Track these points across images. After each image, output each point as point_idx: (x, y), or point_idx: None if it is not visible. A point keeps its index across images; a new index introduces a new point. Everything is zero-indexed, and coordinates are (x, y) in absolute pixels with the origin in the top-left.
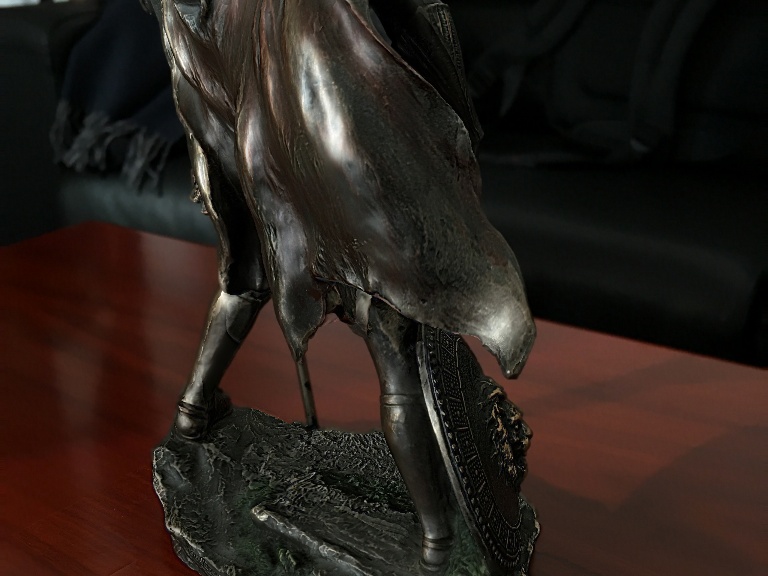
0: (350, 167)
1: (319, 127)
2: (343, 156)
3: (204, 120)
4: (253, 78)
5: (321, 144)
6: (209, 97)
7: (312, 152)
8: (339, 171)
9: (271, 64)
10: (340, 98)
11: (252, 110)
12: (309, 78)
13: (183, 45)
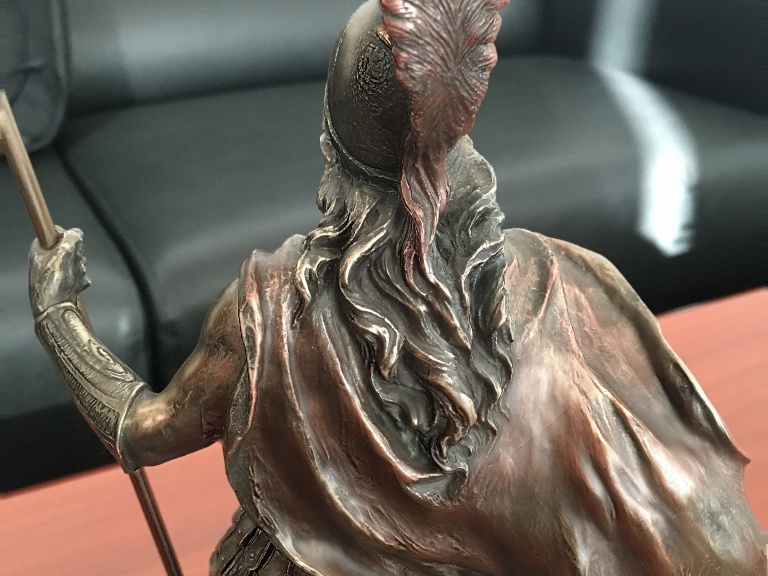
0: (756, 565)
1: (731, 550)
2: (753, 561)
3: (373, 571)
4: (594, 530)
5: (735, 562)
6: (428, 553)
7: (726, 572)
8: (751, 574)
9: (651, 517)
10: (740, 518)
11: (602, 559)
12: (713, 516)
13: (377, 517)
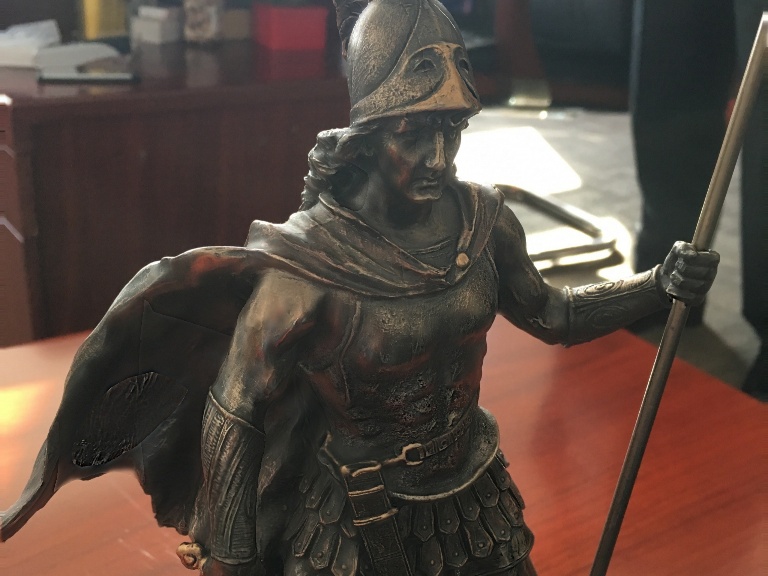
0: None
1: None
2: None
3: None
4: None
5: None
6: None
7: None
8: None
9: None
10: None
11: None
12: None
13: None
